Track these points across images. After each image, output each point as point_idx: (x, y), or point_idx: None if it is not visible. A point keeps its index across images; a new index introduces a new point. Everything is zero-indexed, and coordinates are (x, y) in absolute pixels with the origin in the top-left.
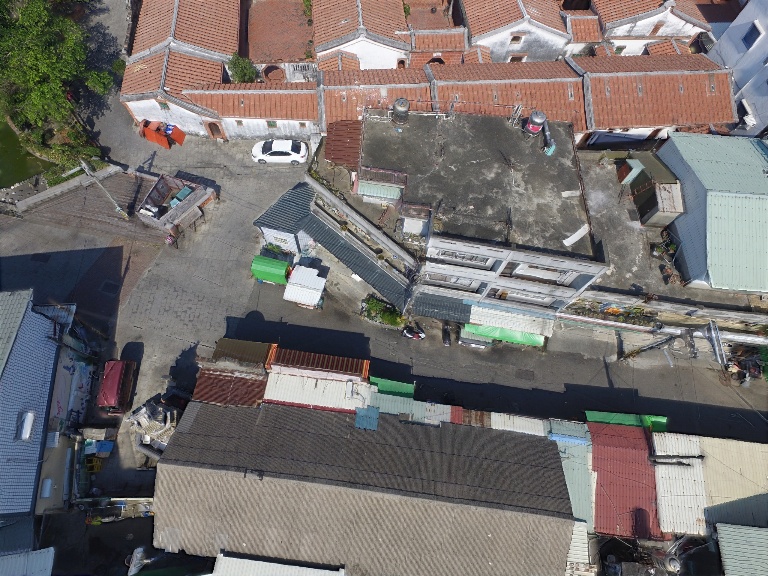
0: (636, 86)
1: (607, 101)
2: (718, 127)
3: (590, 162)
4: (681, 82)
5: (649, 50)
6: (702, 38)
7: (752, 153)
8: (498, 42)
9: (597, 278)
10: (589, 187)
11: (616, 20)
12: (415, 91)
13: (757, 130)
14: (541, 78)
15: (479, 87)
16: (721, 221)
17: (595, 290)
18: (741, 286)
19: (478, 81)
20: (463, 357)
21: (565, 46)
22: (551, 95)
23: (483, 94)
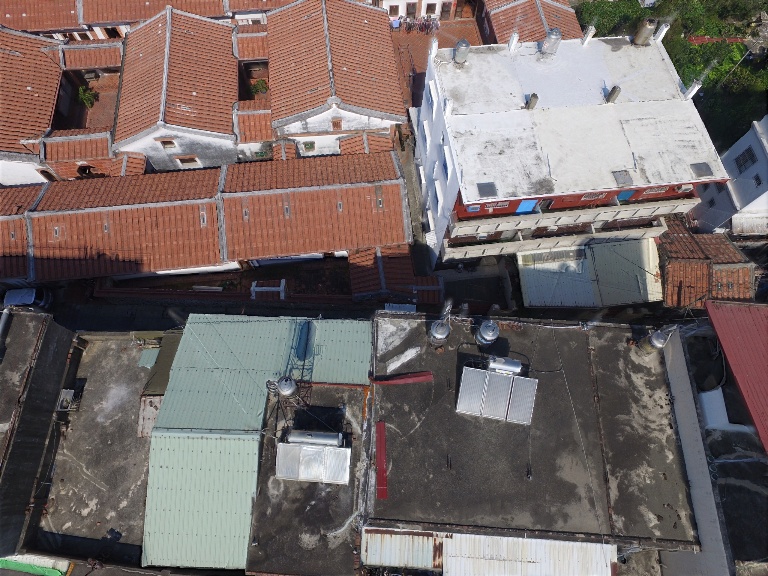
0: (282, 206)
1: (244, 226)
2: (393, 248)
3: (128, 342)
4: (339, 198)
5: (340, 146)
6: (406, 128)
7: (280, 347)
8: (147, 147)
9: (65, 523)
10: (111, 380)
11: (282, 117)
12: (7, 224)
13: (437, 251)
14: (169, 199)
15: (85, 216)
16: (167, 471)
17: (31, 554)
18: (187, 561)
19: (82, 210)
20: (13, 571)
21: (237, 146)
22: (177, 221)
23: (90, 225)
